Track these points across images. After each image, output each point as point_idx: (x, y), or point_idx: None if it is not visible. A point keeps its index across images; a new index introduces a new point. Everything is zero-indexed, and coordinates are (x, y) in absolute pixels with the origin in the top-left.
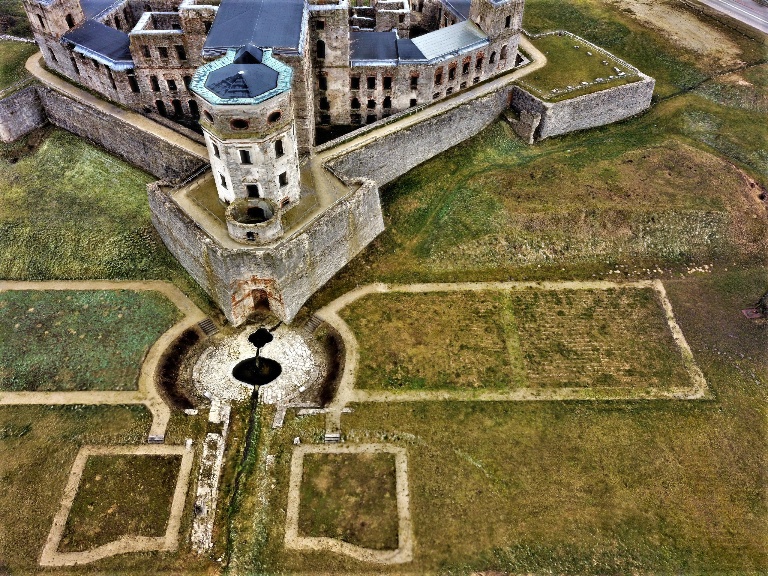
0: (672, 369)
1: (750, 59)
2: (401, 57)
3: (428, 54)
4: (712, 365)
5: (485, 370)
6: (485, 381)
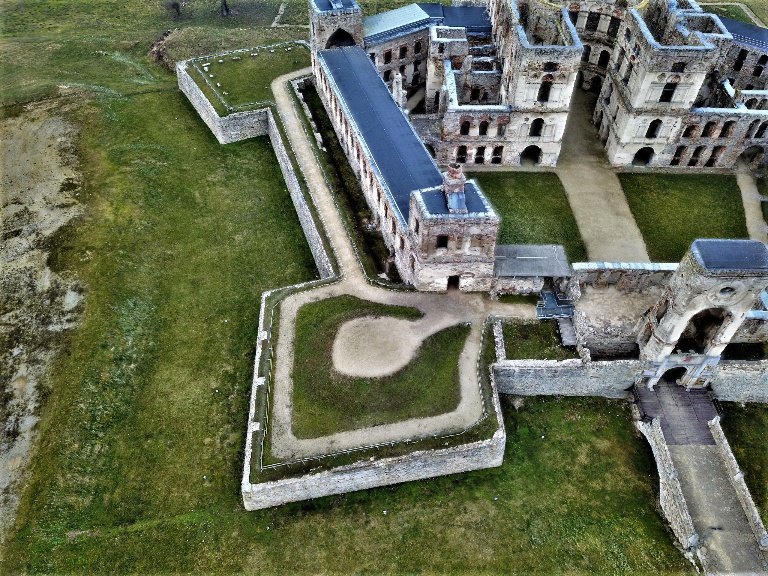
0: (297, 0)
1: (11, 110)
2: (439, 4)
3: (415, 6)
4: (275, 1)
5: (391, 3)
6: (392, 0)
